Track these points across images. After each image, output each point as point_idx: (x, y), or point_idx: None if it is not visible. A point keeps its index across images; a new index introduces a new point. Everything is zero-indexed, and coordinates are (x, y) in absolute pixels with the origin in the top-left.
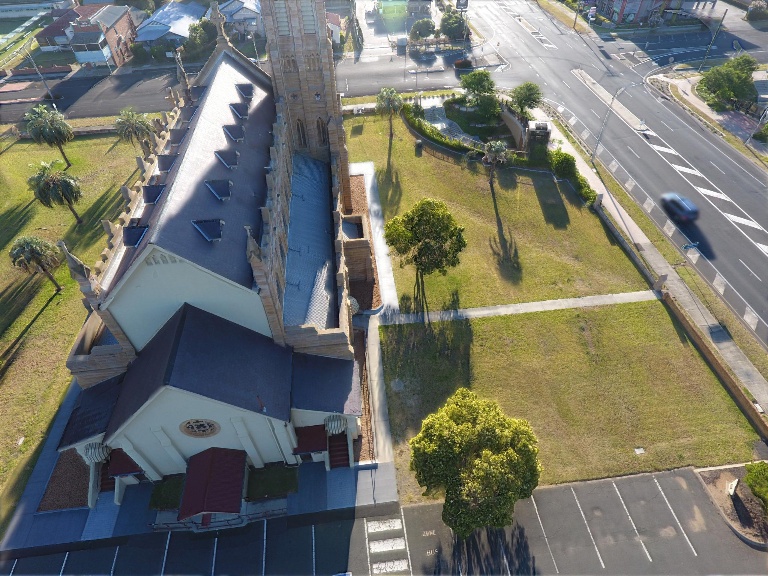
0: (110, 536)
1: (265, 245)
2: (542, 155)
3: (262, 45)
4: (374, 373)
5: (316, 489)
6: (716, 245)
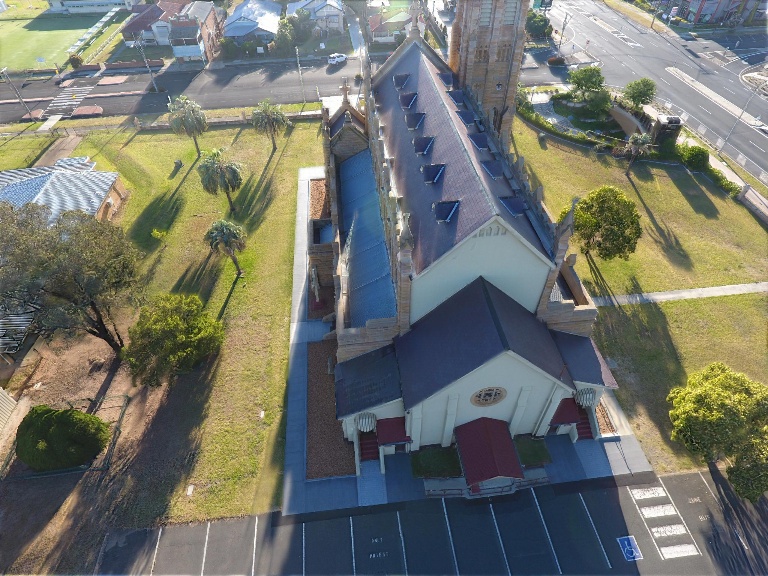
0: (386, 502)
1: (546, 222)
2: (672, 148)
3: (346, 42)
4: None
5: (569, 459)
6: None
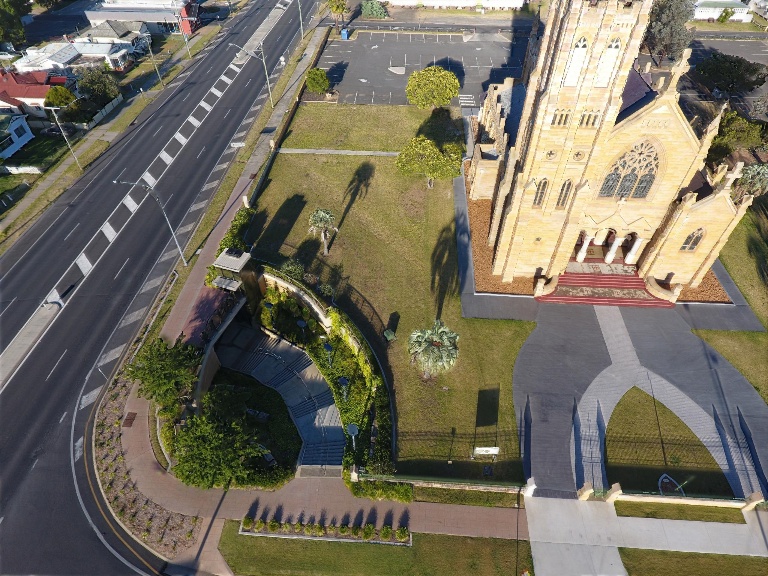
0: None
1: None
2: None
3: None
4: (470, 137)
5: None
6: (197, 168)
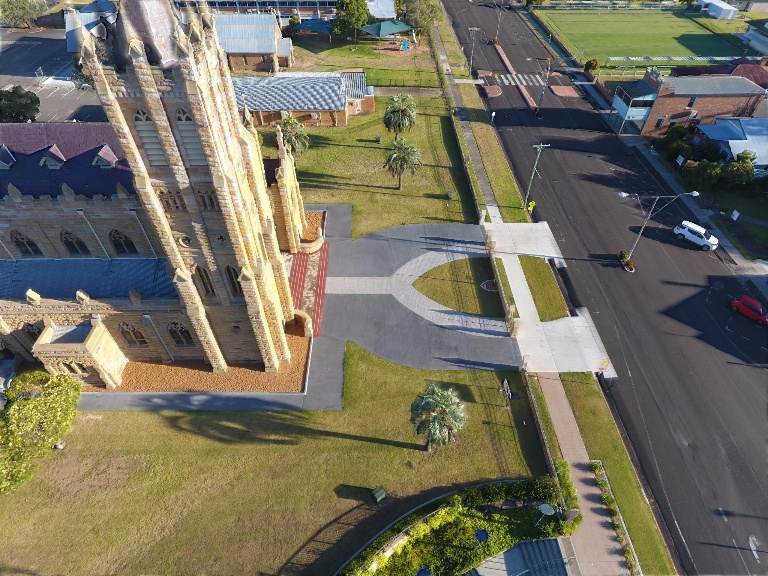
0: None
1: None
2: None
3: None
4: None
5: None
6: None
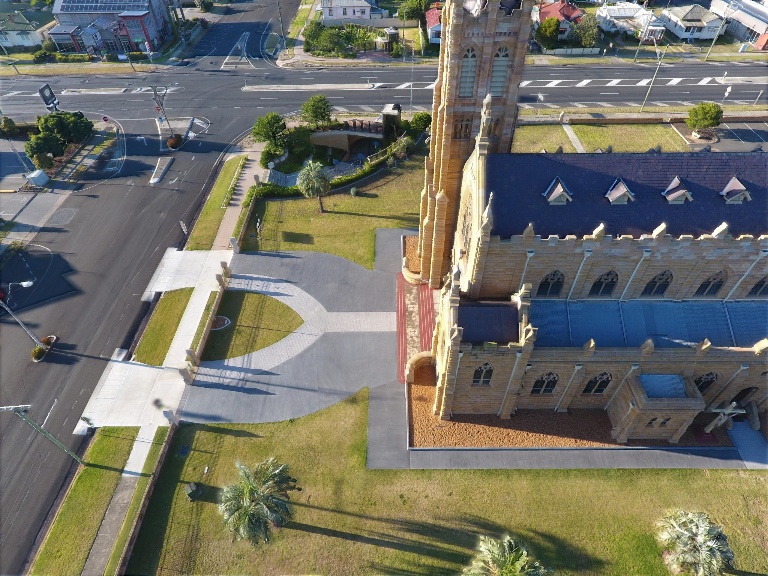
0: None
1: None
2: None
3: None
4: None
5: None
6: None
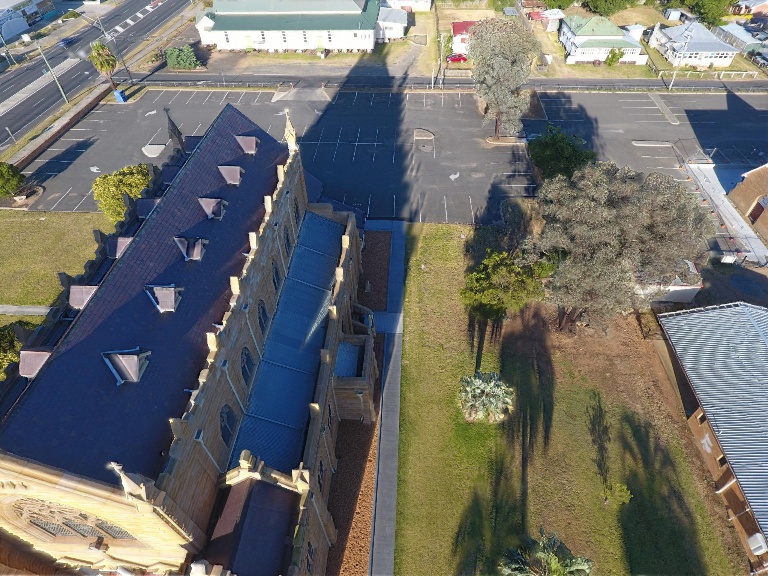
0: None
1: None
2: None
3: None
4: None
5: None
6: None
